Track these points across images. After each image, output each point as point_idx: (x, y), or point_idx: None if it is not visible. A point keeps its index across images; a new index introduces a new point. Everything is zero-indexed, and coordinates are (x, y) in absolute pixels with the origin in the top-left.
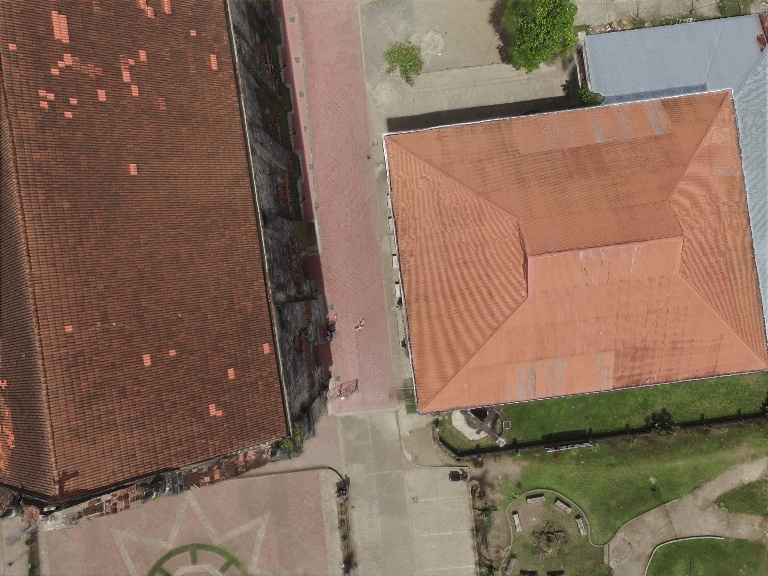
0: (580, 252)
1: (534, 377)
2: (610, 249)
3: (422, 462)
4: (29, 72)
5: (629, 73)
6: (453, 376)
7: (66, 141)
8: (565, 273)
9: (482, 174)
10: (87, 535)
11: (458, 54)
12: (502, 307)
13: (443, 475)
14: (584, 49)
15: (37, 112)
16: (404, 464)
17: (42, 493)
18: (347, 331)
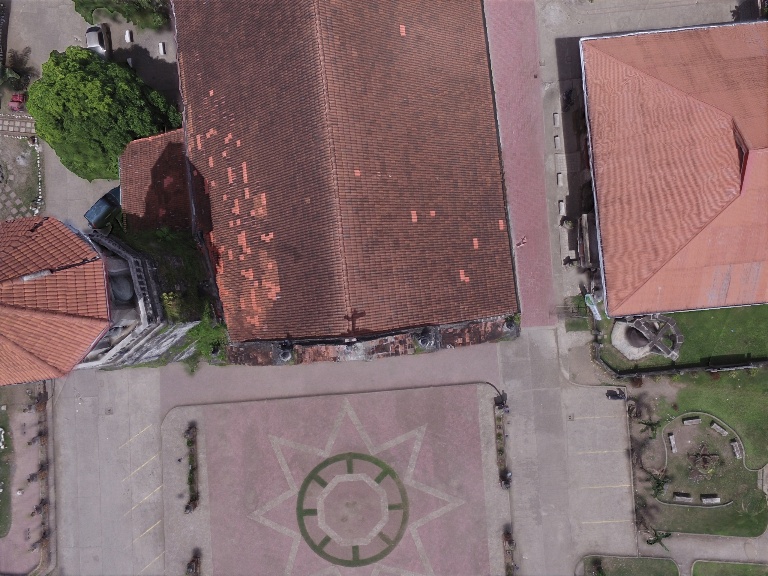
0: None
1: (728, 282)
2: None
3: (580, 380)
4: None
5: None
6: (650, 277)
7: None
8: None
9: (688, 77)
10: (245, 440)
11: None
12: (711, 205)
13: (600, 394)
14: None
15: None
16: (561, 382)
17: (323, 335)
18: None
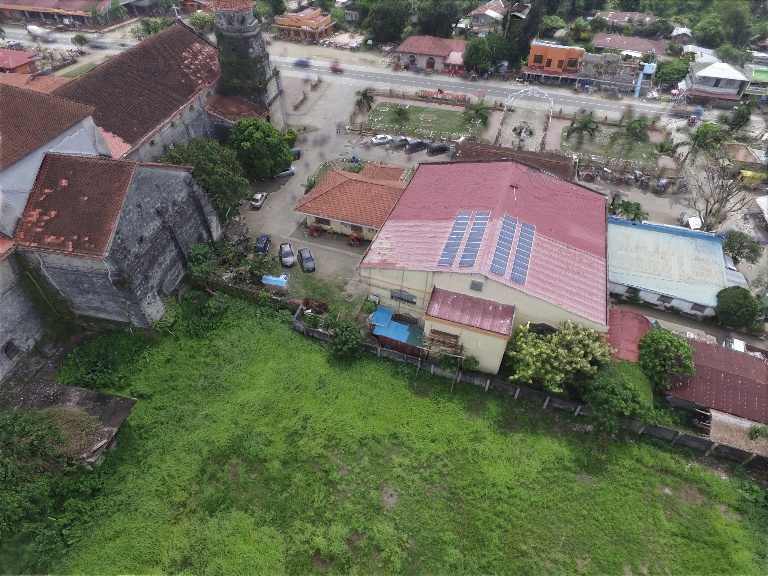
0: None
1: None
2: None
3: None
4: None
5: None
6: None
7: None
8: None
9: None
10: None
11: None
12: (55, 78)
13: None
14: None
15: None
16: None
17: (186, 29)
18: None
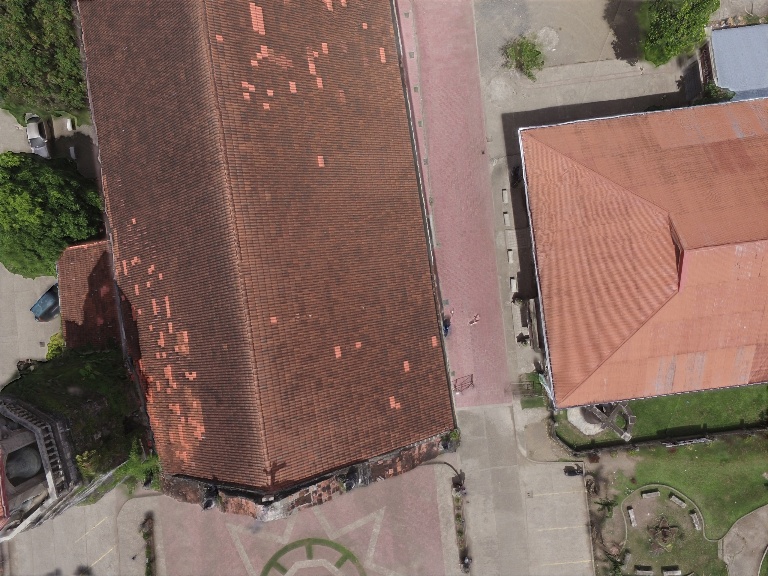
0: (736, 246)
1: (674, 371)
2: (766, 243)
3: (537, 457)
4: (233, 63)
5: (752, 69)
6: (595, 370)
7: (265, 133)
8: (719, 267)
9: (625, 168)
10: (203, 530)
11: (572, 50)
12: (651, 301)
13: (558, 470)
14: (711, 44)
15: (241, 103)
16: (519, 459)
17: (245, 484)
18: (462, 326)
